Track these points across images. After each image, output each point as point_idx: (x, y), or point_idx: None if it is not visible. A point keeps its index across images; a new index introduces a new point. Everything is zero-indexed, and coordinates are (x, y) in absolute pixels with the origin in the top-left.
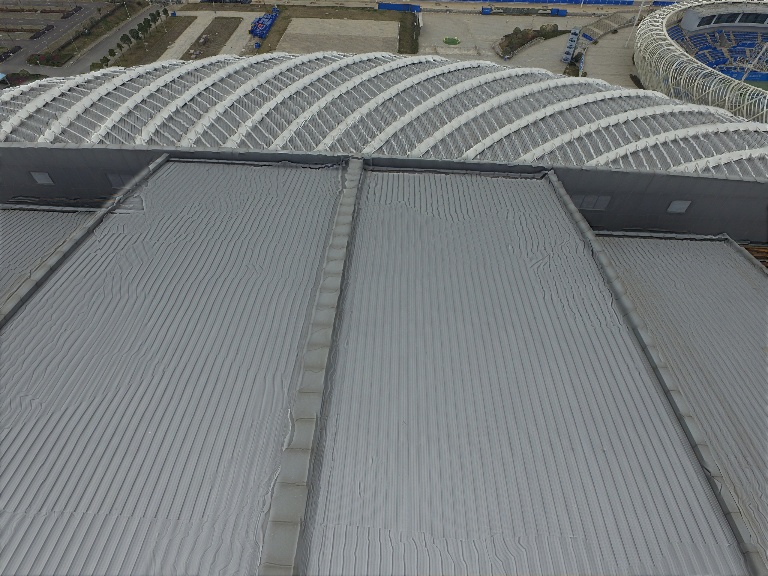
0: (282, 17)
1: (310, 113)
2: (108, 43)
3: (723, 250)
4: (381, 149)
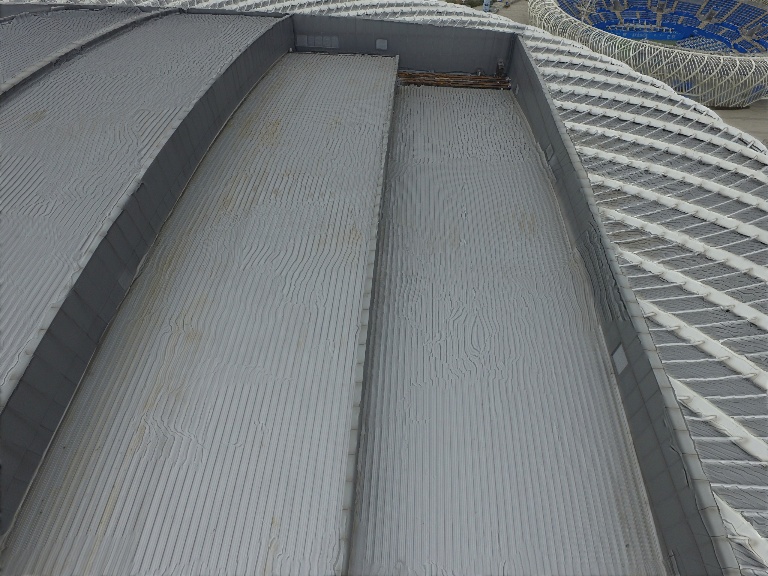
0: None
1: None
2: None
3: (386, 59)
4: None
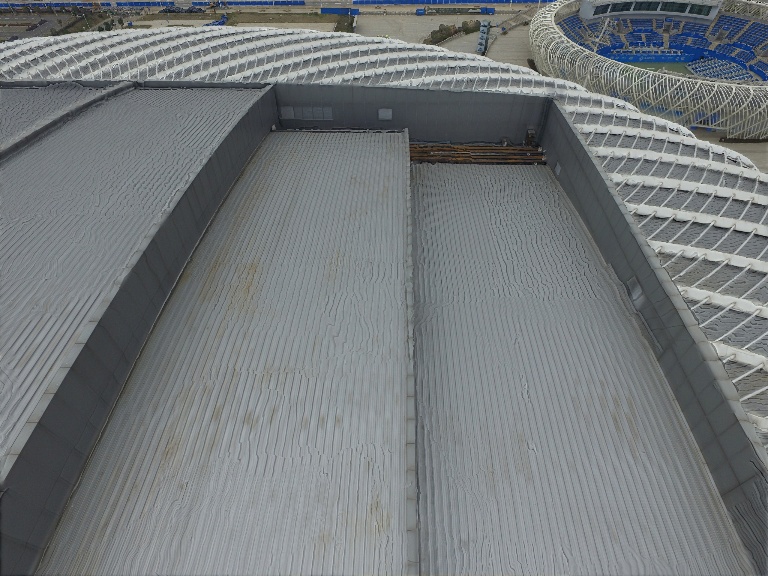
0: (229, 23)
1: (124, 60)
2: None
3: (393, 136)
4: None
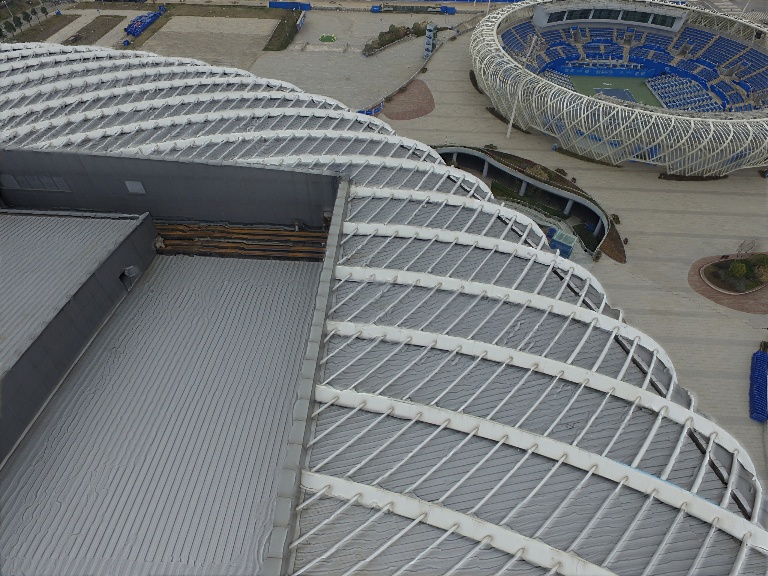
0: (164, 15)
1: None
2: None
3: (116, 228)
4: None
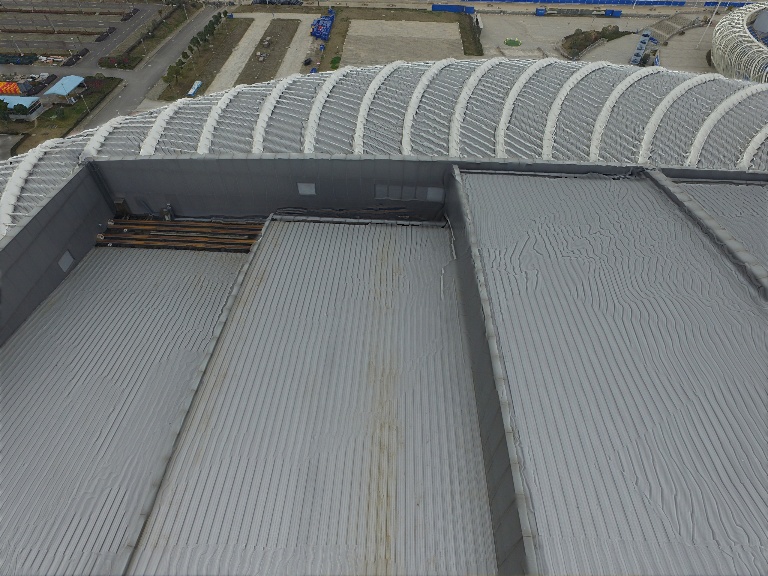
0: (340, 19)
1: (552, 122)
2: (173, 45)
3: None
4: (652, 159)
